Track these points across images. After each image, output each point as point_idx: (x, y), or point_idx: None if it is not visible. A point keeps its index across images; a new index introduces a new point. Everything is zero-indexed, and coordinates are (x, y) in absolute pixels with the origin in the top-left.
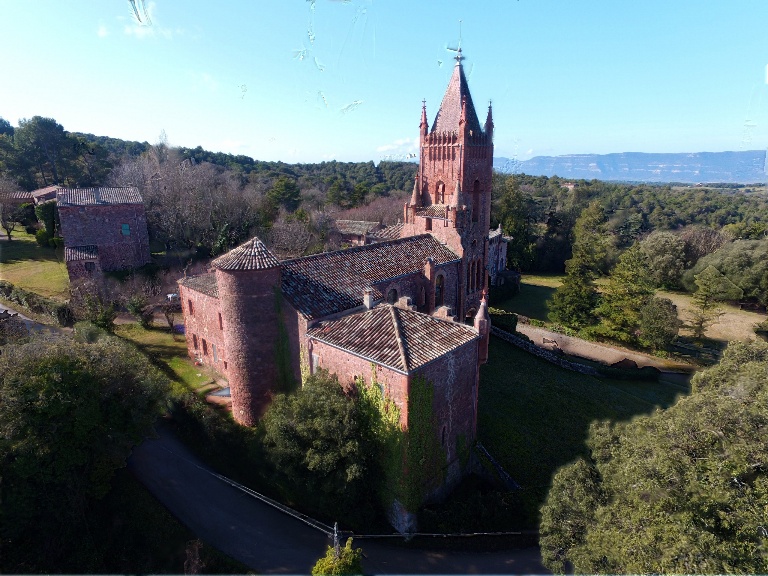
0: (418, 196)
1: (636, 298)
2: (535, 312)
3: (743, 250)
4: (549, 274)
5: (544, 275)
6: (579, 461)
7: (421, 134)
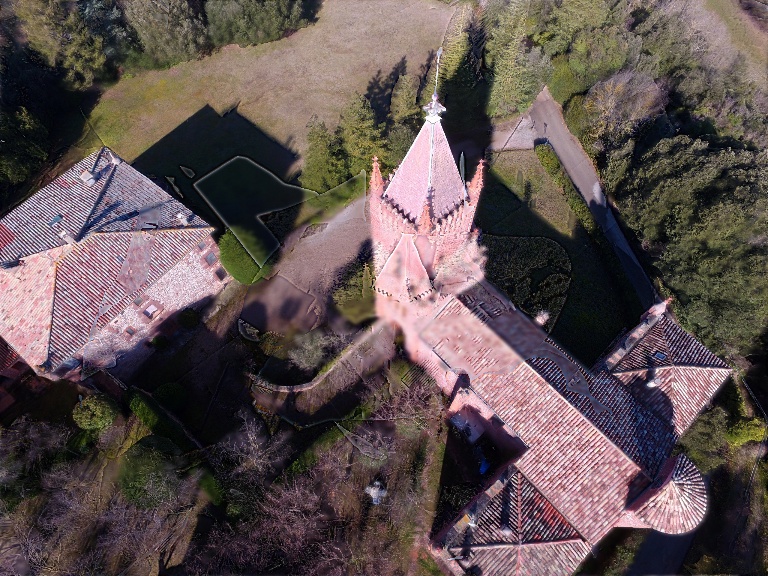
0: None
1: (376, 139)
2: None
3: None
4: (69, 128)
5: (75, 136)
6: (700, 302)
7: None
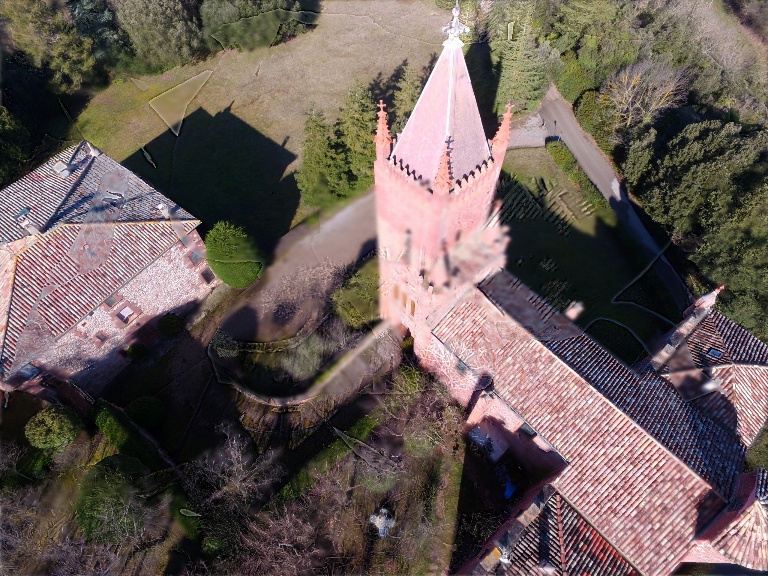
0: None
1: None
2: None
3: None
4: (54, 132)
5: None
6: None
7: None
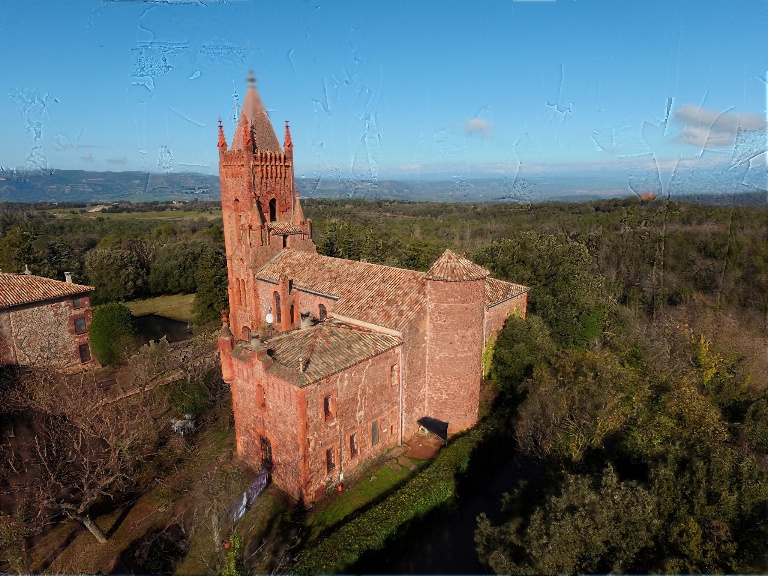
0: (260, 216)
1: None
2: (148, 343)
3: (185, 249)
4: None
5: None
6: None
7: (249, 151)
